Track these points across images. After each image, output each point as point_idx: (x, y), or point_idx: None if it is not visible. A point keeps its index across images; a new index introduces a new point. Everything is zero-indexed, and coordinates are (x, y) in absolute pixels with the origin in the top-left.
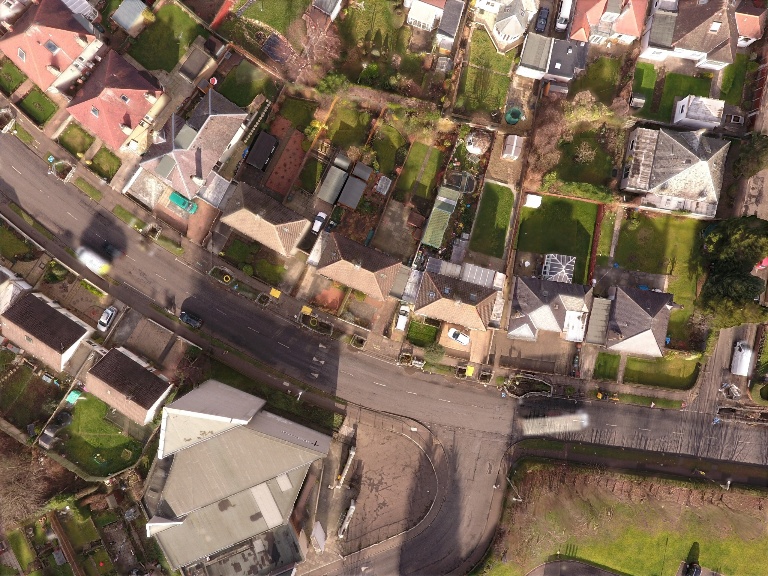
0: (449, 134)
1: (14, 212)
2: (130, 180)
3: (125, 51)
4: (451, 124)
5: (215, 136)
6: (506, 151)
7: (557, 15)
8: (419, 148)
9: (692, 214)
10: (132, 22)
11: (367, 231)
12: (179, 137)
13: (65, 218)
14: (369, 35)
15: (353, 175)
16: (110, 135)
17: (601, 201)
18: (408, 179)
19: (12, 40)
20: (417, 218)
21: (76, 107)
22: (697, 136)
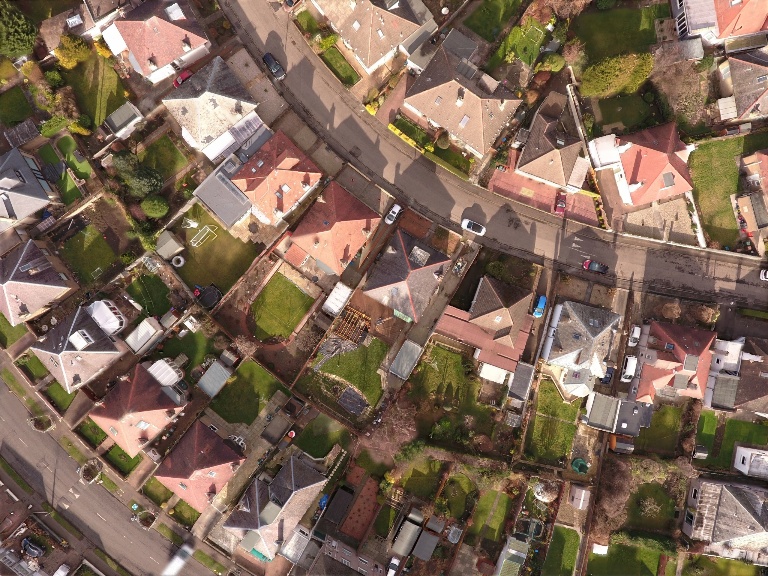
0: (517, 481)
1: (99, 557)
2: (211, 531)
3: (207, 406)
4: (520, 476)
5: (297, 505)
6: (574, 504)
7: (622, 369)
8: (488, 493)
9: (754, 564)
10: (217, 390)
11: (438, 573)
12: (264, 513)
13: (147, 562)
14: (441, 388)
15: (426, 528)
16: (196, 504)
17: (666, 555)
18: (478, 523)
19: (105, 420)
20: (488, 568)
21: (164, 478)
22: (760, 502)
